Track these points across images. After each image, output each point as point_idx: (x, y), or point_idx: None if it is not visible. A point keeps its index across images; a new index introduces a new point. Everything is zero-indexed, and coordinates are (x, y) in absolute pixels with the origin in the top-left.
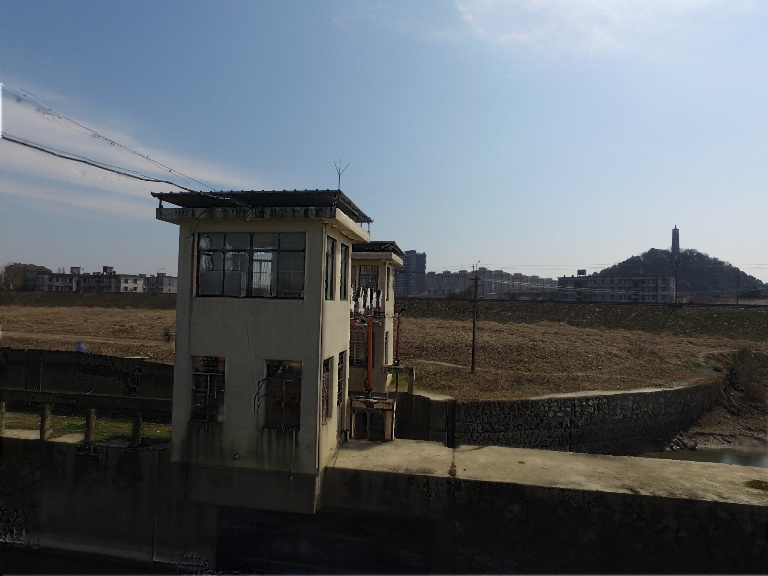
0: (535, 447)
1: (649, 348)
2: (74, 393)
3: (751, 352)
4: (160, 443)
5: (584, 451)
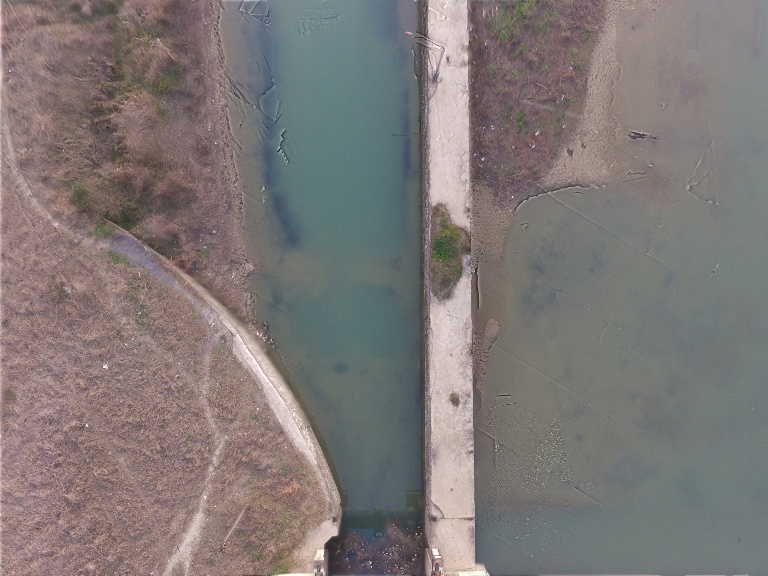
0: (320, 450)
1: (56, 286)
2: None
3: (81, 187)
4: None
5: (304, 413)
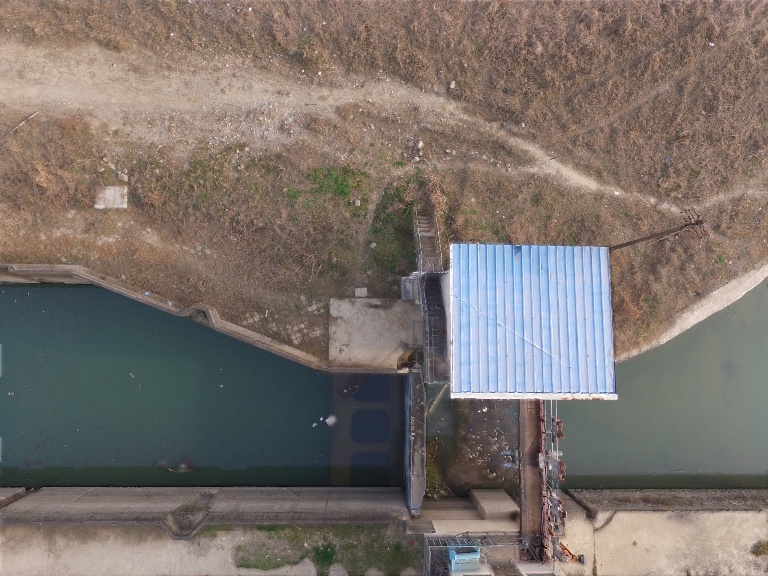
0: None
1: None
2: (284, 523)
3: None
4: (404, 569)
5: None
